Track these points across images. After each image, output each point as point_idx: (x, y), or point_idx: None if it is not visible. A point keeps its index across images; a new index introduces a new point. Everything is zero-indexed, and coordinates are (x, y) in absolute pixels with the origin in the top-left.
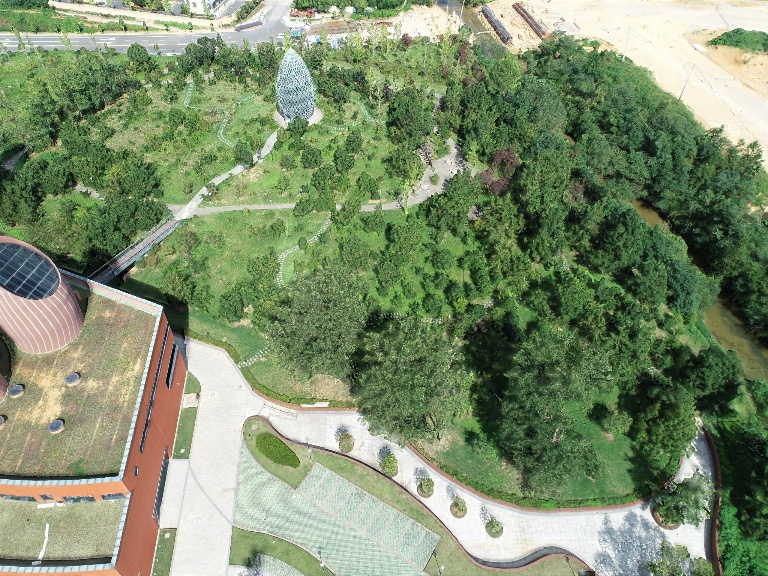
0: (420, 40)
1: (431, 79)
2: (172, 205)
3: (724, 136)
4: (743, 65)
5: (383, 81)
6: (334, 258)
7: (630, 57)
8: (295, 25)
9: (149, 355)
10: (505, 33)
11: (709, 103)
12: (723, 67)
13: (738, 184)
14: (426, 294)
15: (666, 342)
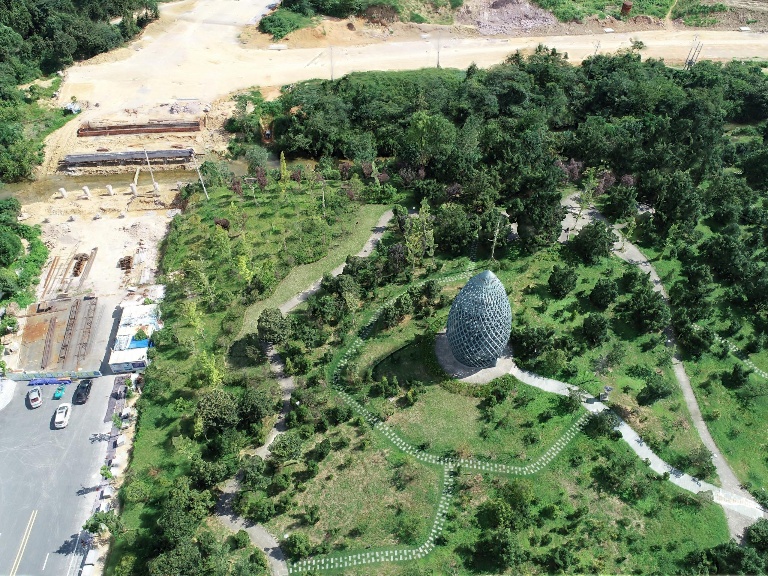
0: (177, 225)
1: (345, 215)
2: (731, 530)
3: (527, 55)
4: (326, 37)
5: (432, 232)
6: (749, 327)
7: (315, 77)
8: (4, 398)
9: None
10: (176, 152)
11: (392, 67)
12: (323, 46)
13: (580, 70)
14: (762, 261)
15: (752, 146)
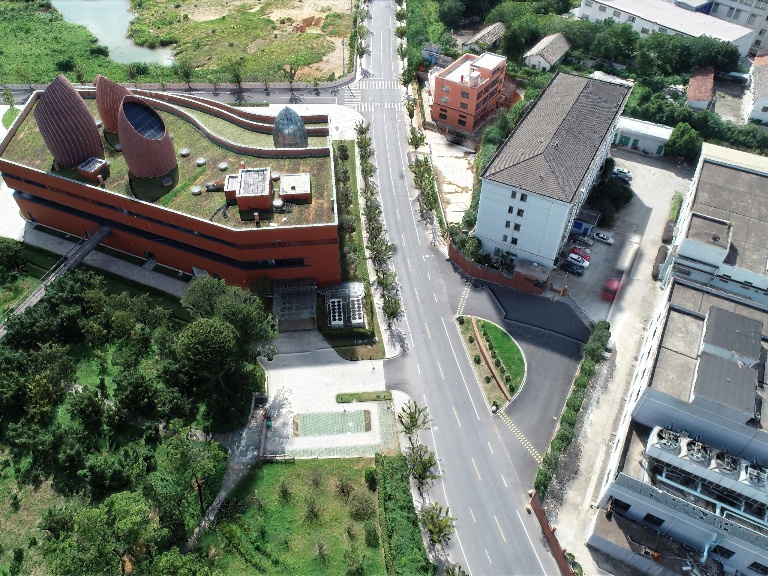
0: None
1: None
2: None
3: None
4: None
5: None
6: None
7: None
8: None
9: (8, 132)
10: None
11: None
12: None
13: None
14: None
15: None
